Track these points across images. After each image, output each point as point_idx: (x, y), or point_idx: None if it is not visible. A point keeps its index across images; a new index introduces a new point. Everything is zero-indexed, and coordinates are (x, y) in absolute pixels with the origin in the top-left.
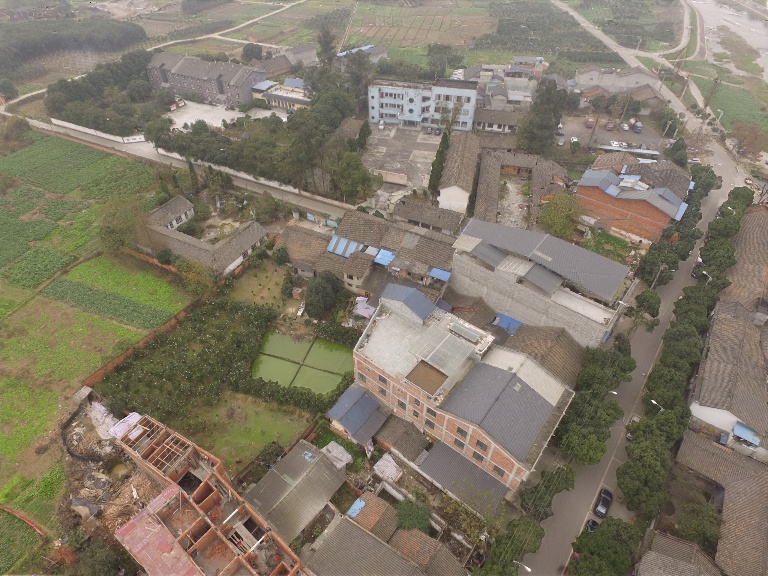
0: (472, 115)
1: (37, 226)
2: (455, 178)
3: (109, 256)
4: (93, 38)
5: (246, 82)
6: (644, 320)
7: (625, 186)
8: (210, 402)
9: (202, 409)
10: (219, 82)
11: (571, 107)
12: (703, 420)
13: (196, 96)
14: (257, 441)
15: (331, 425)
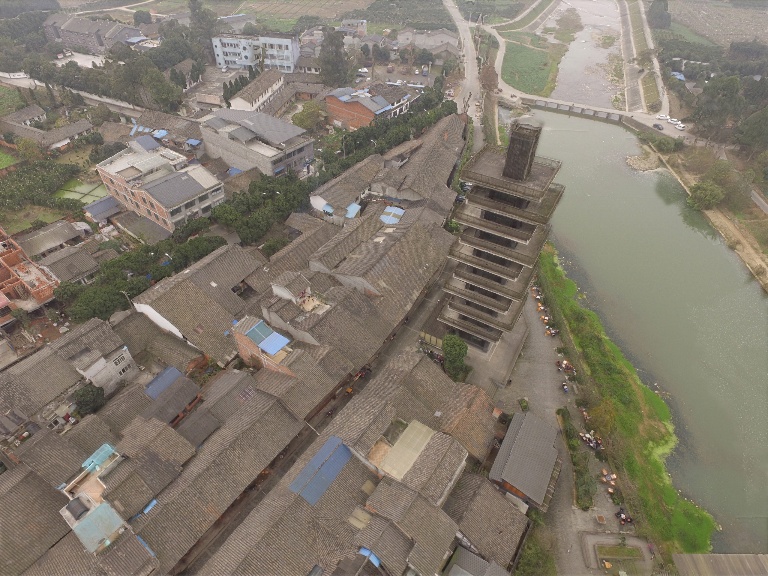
0: (292, 60)
1: None
2: (241, 93)
3: None
4: (8, 6)
5: (119, 36)
6: (317, 165)
7: (354, 95)
8: (13, 207)
9: (8, 213)
10: (98, 36)
11: (383, 58)
12: (318, 209)
13: (81, 48)
14: None
15: (85, 215)
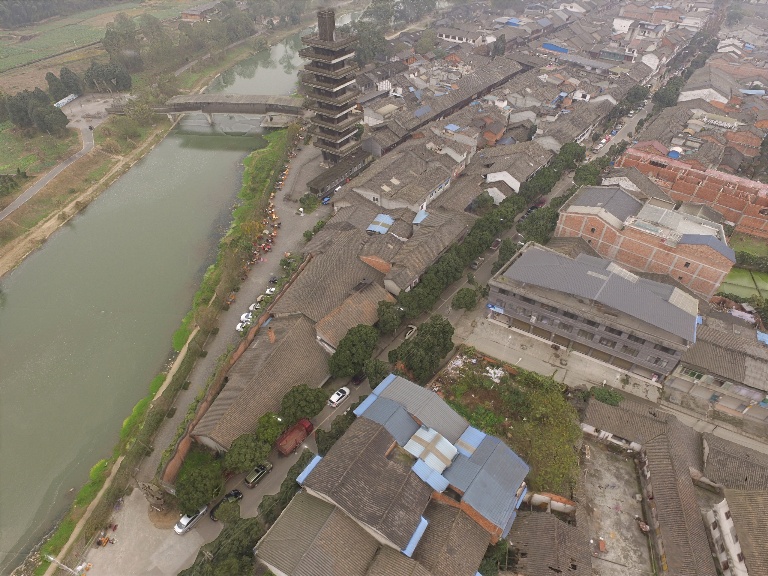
0: None
1: None
2: None
3: None
4: None
5: None
6: (476, 283)
7: None
8: None
9: None
10: None
11: None
12: None
13: None
14: (741, 248)
15: None
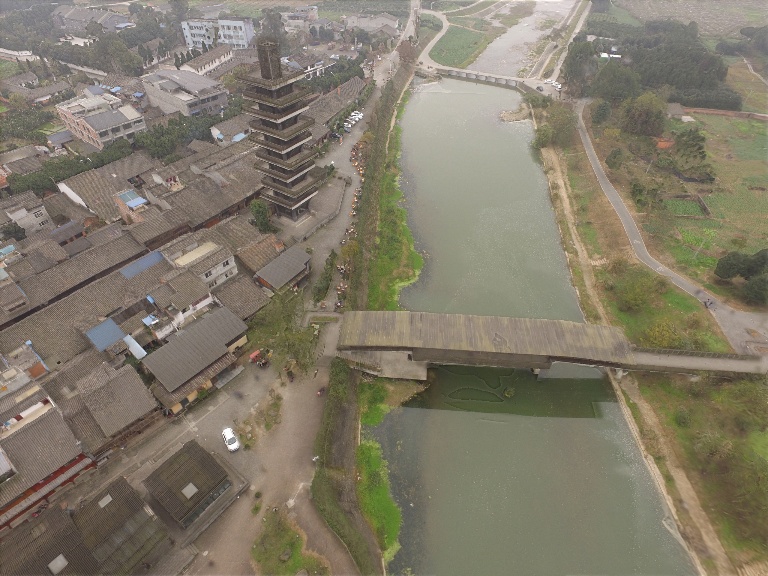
0: (245, 39)
1: None
2: (189, 61)
3: None
4: (28, 1)
5: (109, 22)
6: None
7: None
8: None
9: None
10: None
11: (328, 38)
12: None
13: (80, 33)
14: None
15: (47, 142)
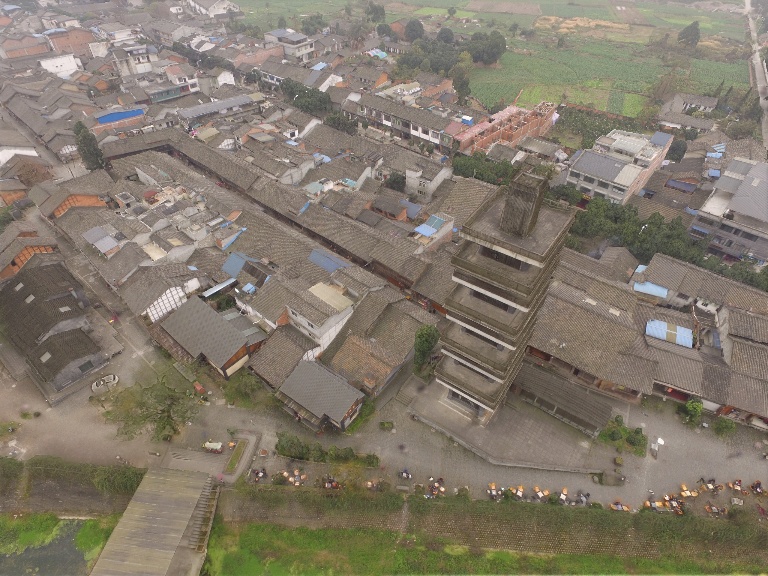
0: None
1: (656, 80)
2: None
3: (650, 99)
4: None
5: None
6: None
7: None
8: (574, 130)
9: None
10: None
11: None
12: None
13: None
14: None
15: None
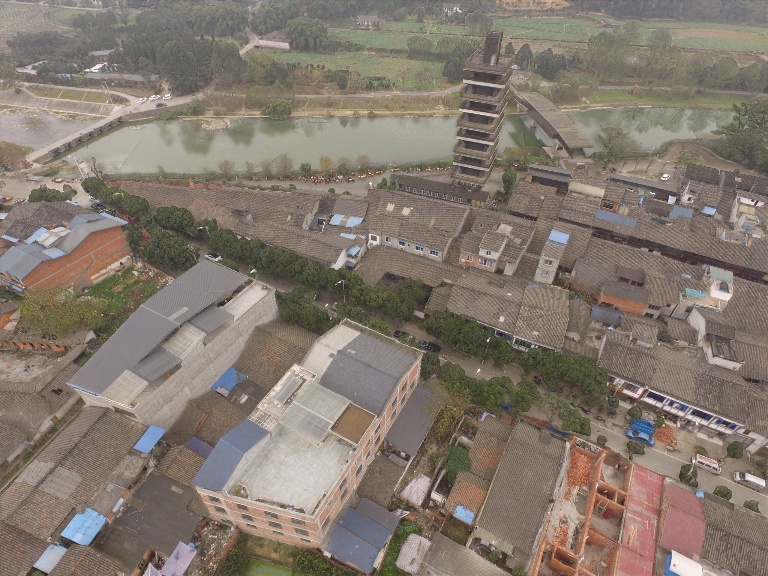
0: None
1: None
2: None
3: None
4: None
5: None
6: None
7: (53, 242)
8: None
9: None
10: None
11: None
12: None
13: None
14: None
15: None
